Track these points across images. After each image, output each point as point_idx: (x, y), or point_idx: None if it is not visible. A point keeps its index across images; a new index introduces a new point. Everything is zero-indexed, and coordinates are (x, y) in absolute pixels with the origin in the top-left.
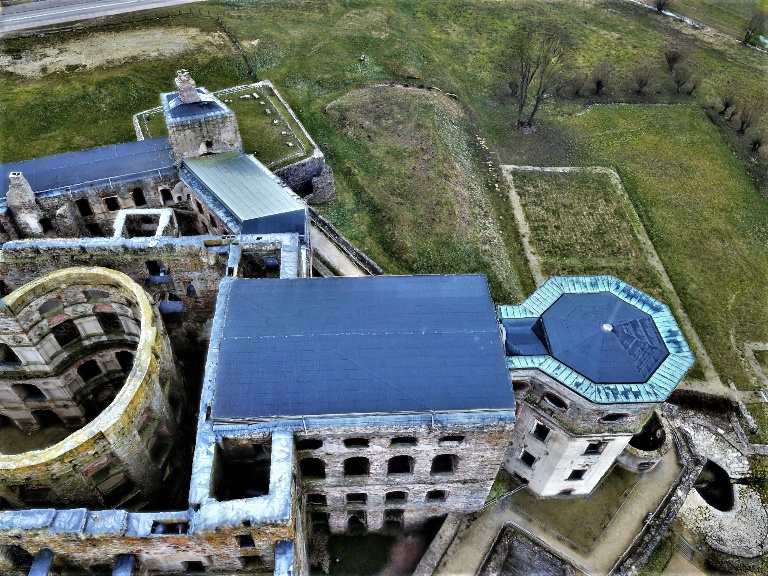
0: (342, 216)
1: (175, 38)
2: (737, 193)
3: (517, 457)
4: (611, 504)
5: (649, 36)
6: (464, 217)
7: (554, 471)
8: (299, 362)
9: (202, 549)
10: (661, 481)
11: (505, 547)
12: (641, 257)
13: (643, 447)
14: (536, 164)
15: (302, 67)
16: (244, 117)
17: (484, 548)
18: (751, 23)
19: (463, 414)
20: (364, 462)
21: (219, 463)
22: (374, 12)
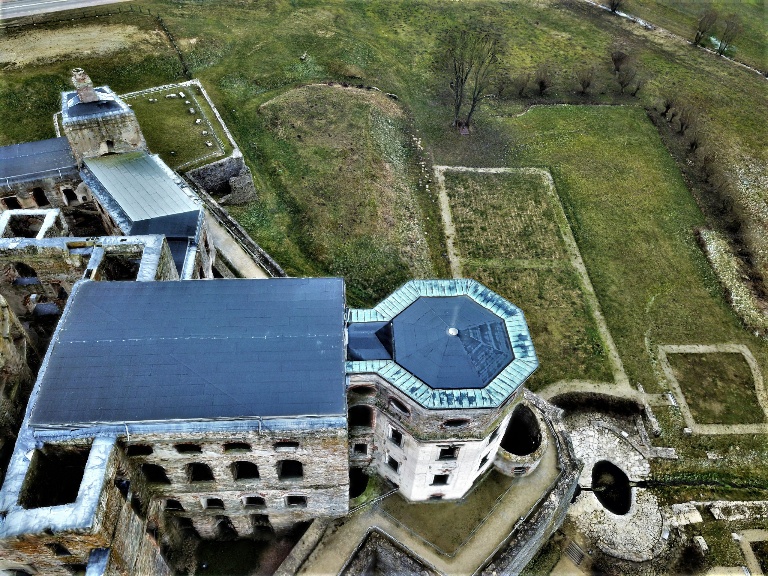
0: (262, 217)
1: (111, 36)
2: (669, 195)
3: (384, 462)
4: (483, 509)
5: (600, 37)
6: (387, 218)
7: (415, 476)
8: (131, 367)
9: (17, 557)
10: (537, 485)
11: (367, 553)
12: (564, 259)
13: (524, 451)
14: (470, 165)
15: (240, 66)
16: (167, 116)
17: (347, 554)
18: (700, 24)
19: (292, 420)
20: (206, 468)
21: (43, 470)
22: (322, 11)
